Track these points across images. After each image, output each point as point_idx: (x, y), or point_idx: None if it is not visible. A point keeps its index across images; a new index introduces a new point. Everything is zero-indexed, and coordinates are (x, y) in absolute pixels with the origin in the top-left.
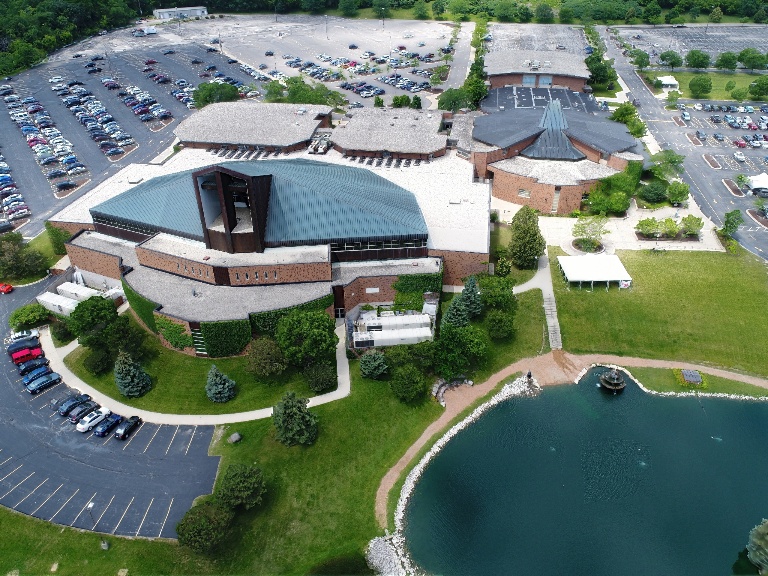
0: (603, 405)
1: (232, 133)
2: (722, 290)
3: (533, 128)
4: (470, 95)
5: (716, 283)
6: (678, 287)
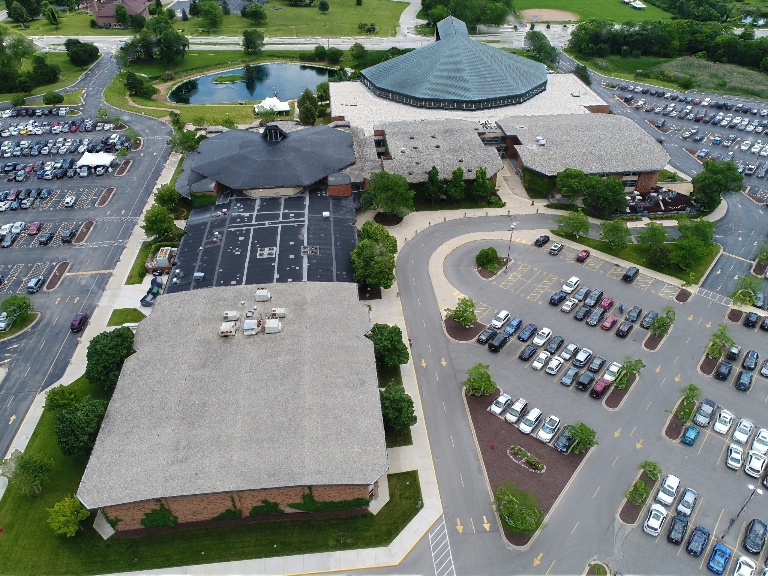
0: (281, 98)
1: (568, 118)
2: (207, 111)
3: (295, 135)
4: (369, 184)
5: (207, 113)
6: (229, 111)
